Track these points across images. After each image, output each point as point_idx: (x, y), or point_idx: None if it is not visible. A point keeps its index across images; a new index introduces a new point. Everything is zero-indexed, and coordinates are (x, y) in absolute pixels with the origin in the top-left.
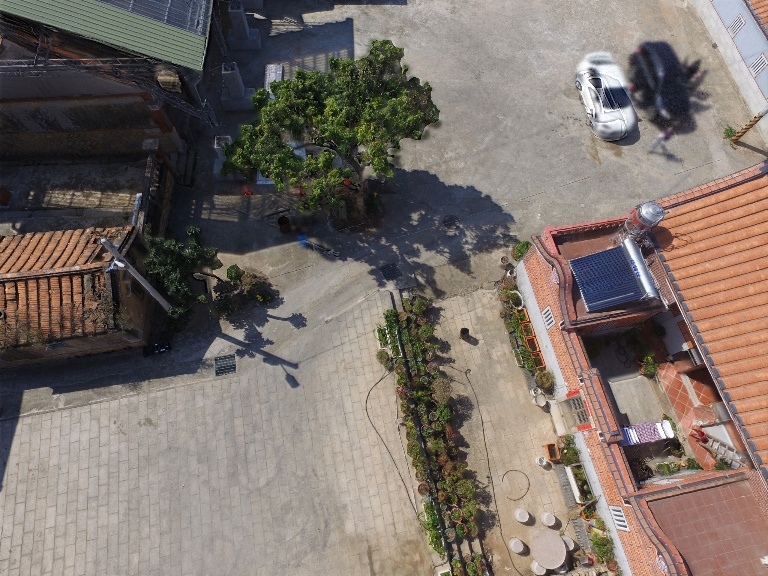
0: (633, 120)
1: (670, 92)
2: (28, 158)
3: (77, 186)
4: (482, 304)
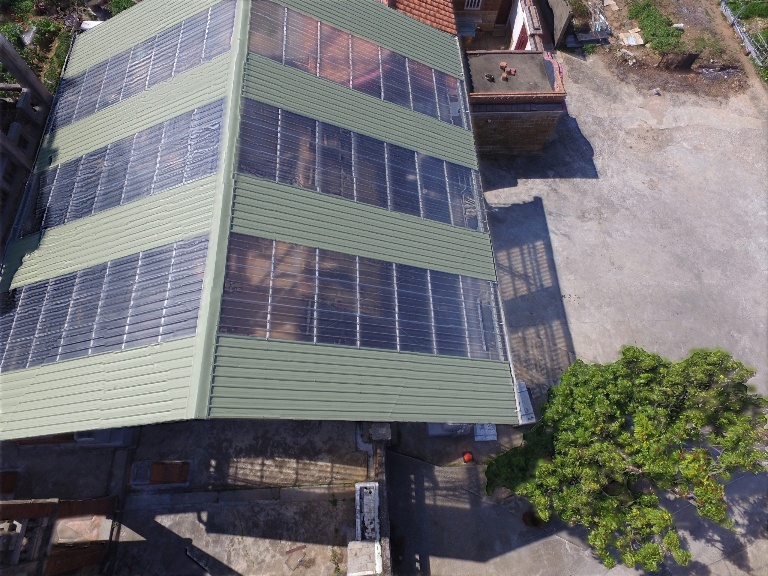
0: None
1: None
2: None
3: (266, 450)
4: None
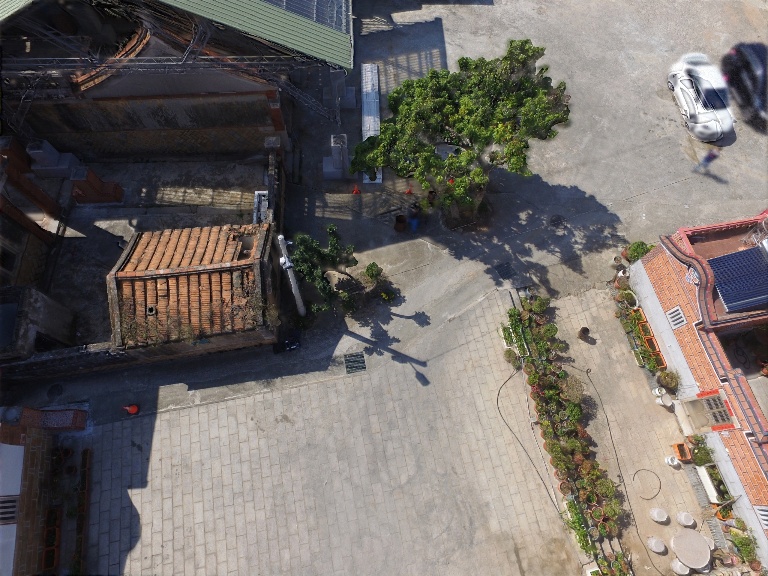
0: (728, 121)
1: (762, 93)
2: (136, 155)
3: (188, 183)
4: (596, 304)
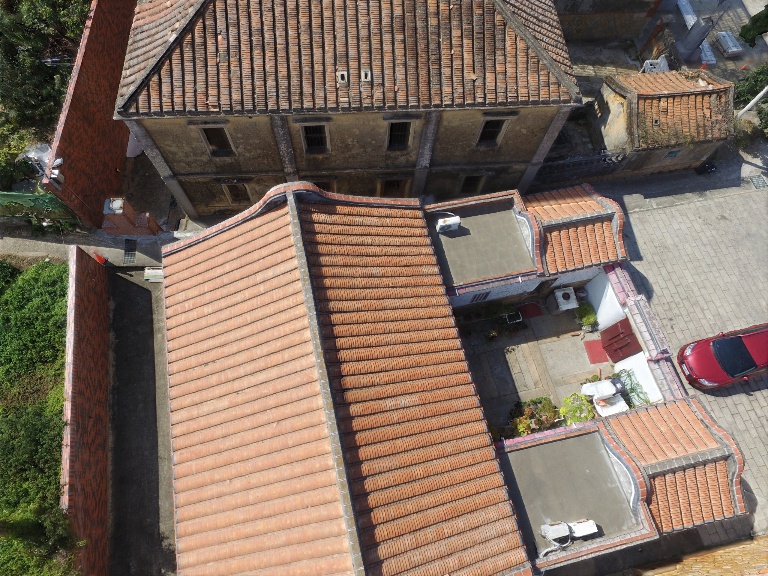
0: None
1: None
2: None
3: None
4: None
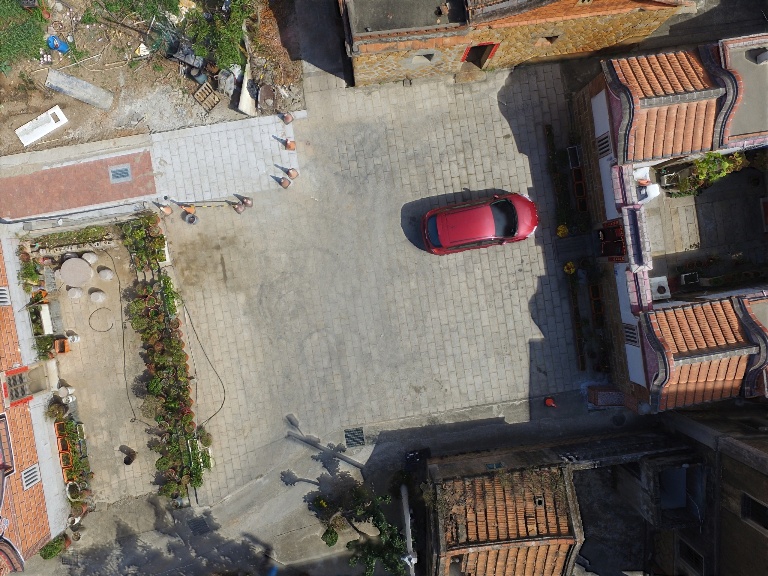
0: None
1: None
2: None
3: None
4: (111, 487)
